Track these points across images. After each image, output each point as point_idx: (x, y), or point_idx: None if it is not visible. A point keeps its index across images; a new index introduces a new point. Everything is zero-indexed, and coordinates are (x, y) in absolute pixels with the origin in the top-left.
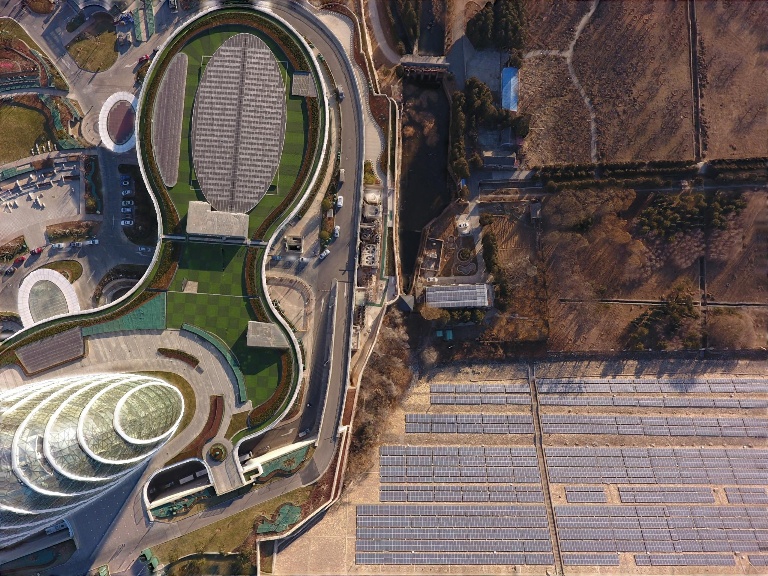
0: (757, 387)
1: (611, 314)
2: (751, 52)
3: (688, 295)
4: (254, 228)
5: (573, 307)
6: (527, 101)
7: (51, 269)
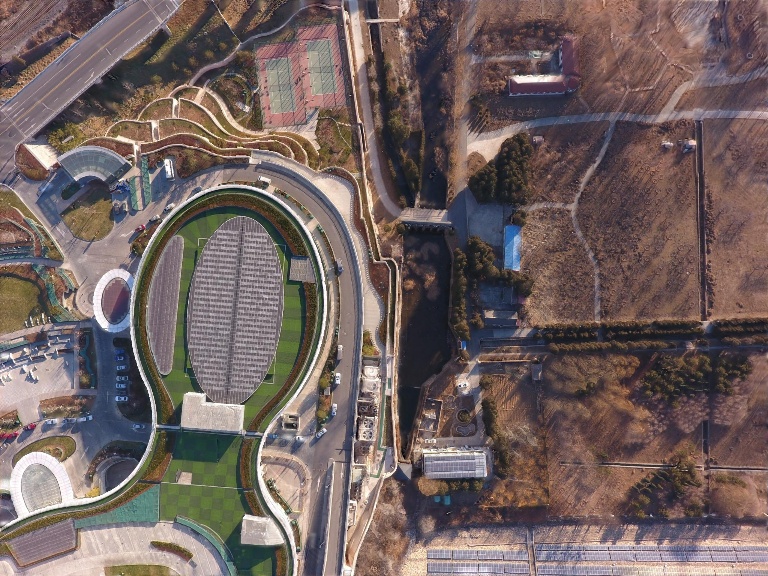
0: (759, 556)
1: (612, 478)
2: (760, 206)
3: (691, 463)
4: (250, 418)
5: (573, 470)
6: (530, 256)
7: None
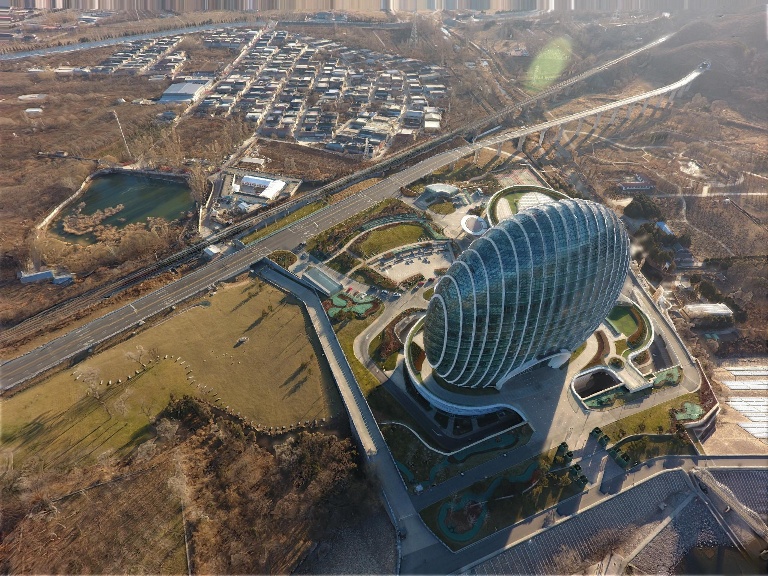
0: None
1: None
2: None
3: None
4: None
5: None
6: None
7: None
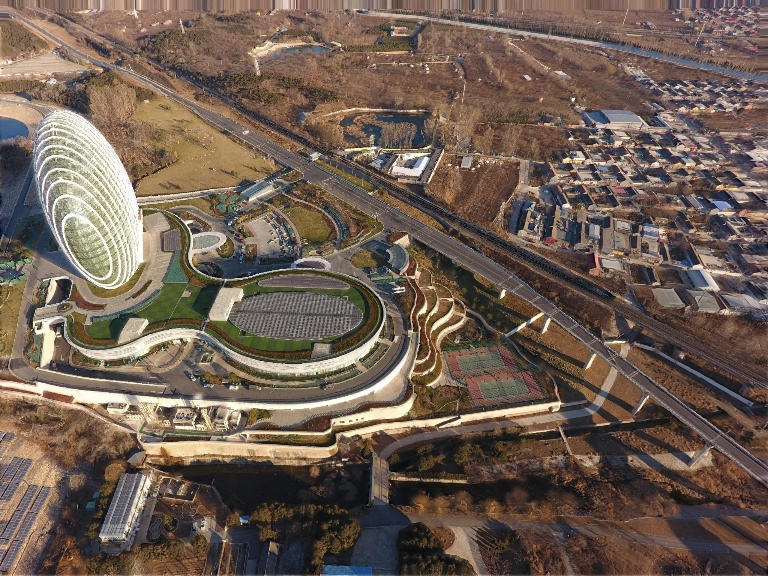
0: None
1: None
2: None
3: None
4: (217, 324)
5: None
6: None
7: None
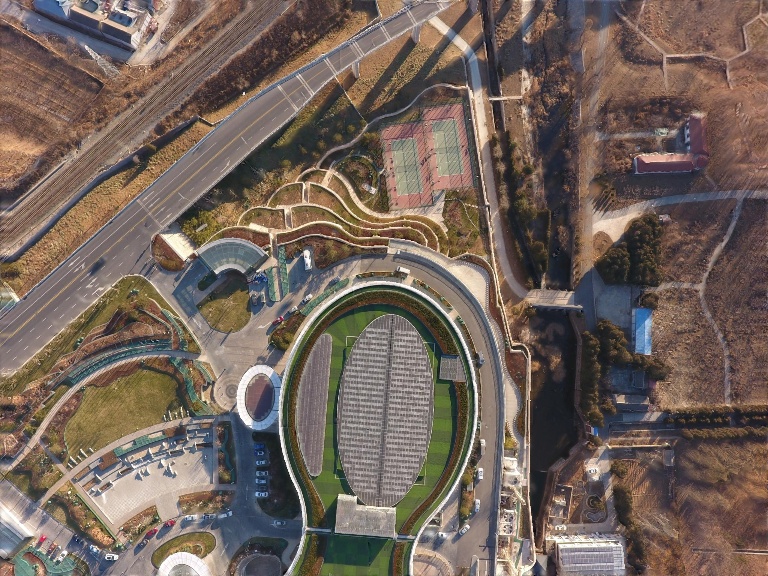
0: None
1: (746, 565)
2: None
3: None
4: (401, 521)
5: (706, 557)
6: (658, 337)
7: (189, 553)
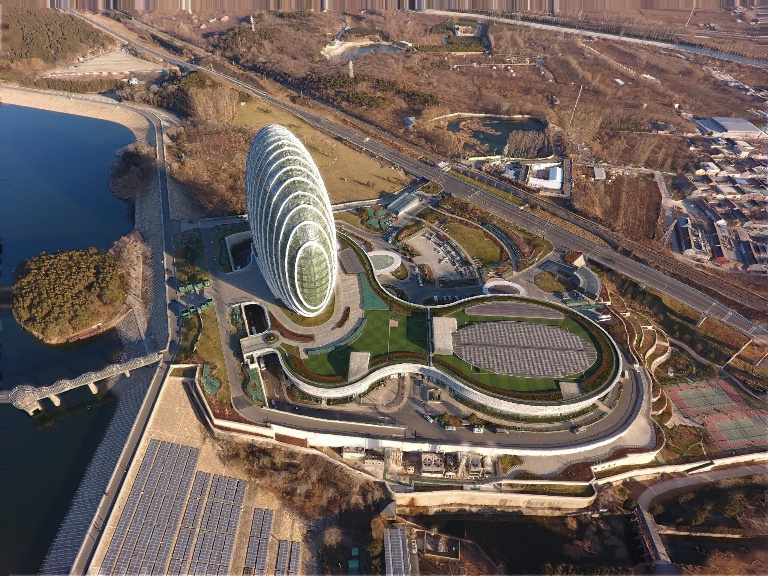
0: None
1: None
2: None
3: None
4: (443, 358)
5: None
6: None
7: None
